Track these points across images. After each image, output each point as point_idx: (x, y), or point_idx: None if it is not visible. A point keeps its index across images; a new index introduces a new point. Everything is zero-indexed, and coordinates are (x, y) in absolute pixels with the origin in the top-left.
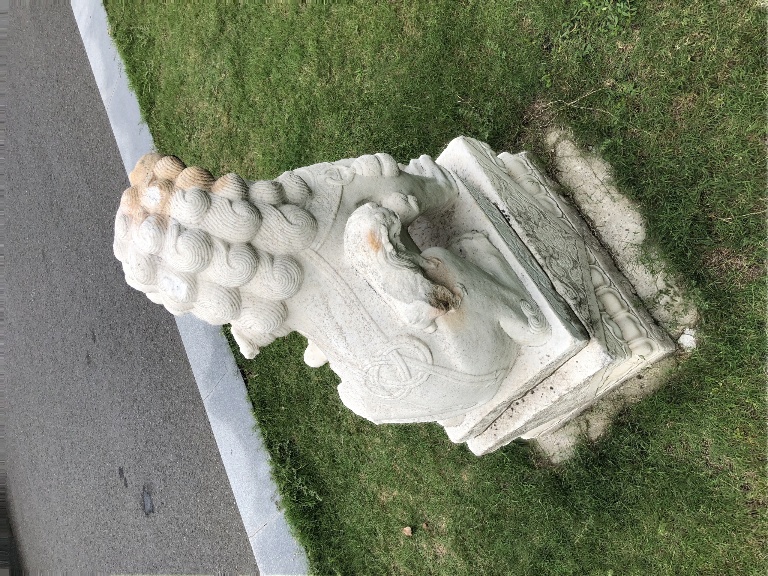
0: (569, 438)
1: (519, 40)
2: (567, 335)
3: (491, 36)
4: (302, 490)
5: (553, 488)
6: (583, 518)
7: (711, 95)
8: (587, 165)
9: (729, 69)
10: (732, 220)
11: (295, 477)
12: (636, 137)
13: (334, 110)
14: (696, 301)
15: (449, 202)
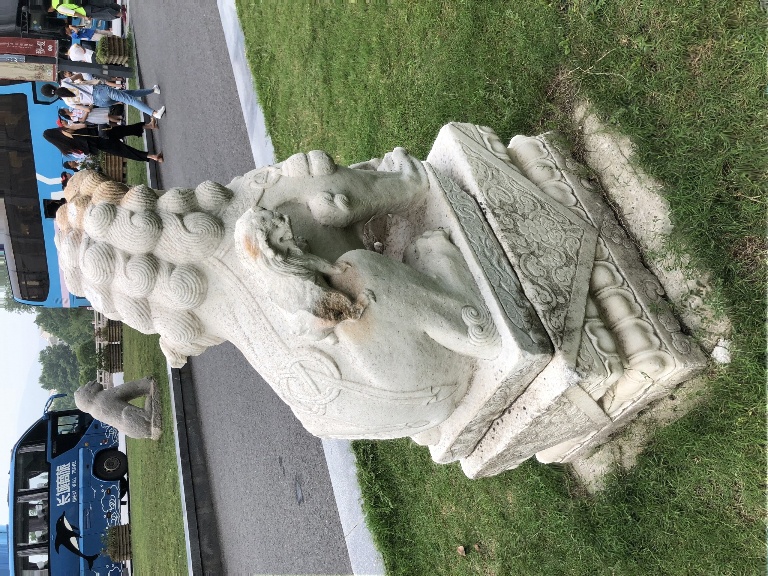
0: (603, 465)
1: (537, 4)
2: (515, 348)
3: (512, 5)
4: (379, 495)
5: (582, 523)
6: (612, 562)
7: (730, 38)
8: (614, 141)
9: (750, 1)
10: (760, 198)
11: (373, 481)
12: (656, 102)
13: (392, 106)
14: (712, 305)
15: (418, 197)
